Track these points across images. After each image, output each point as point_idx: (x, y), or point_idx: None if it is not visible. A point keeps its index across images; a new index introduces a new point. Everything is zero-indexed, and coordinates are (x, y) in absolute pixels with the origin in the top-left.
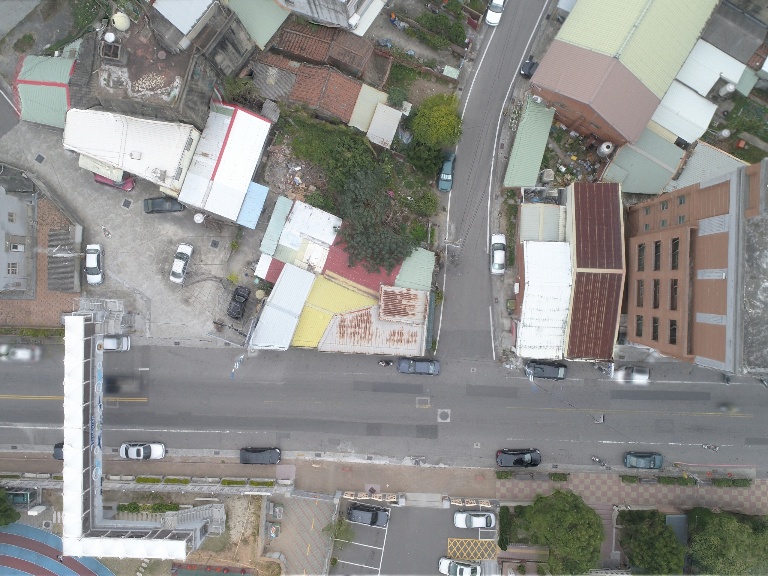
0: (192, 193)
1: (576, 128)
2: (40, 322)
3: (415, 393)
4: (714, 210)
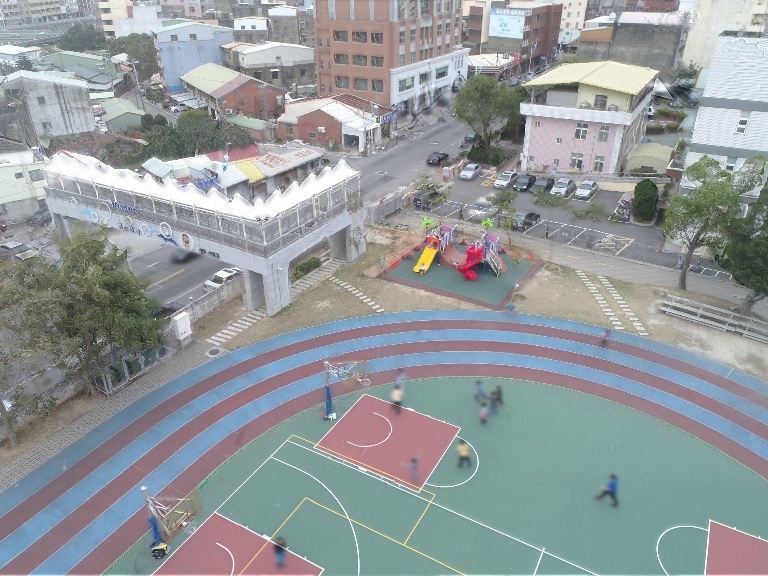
0: None
1: (260, 118)
2: None
3: None
4: (326, 7)
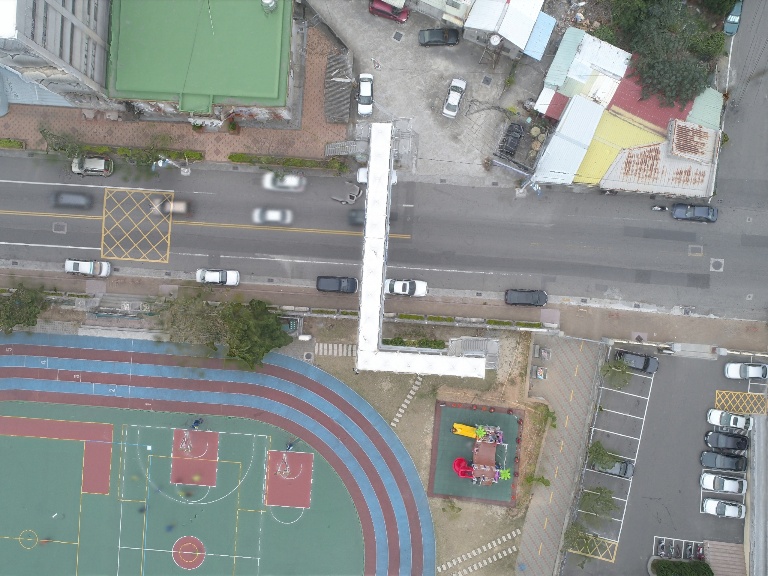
0: (483, 18)
1: None
2: (303, 153)
3: (688, 241)
4: None
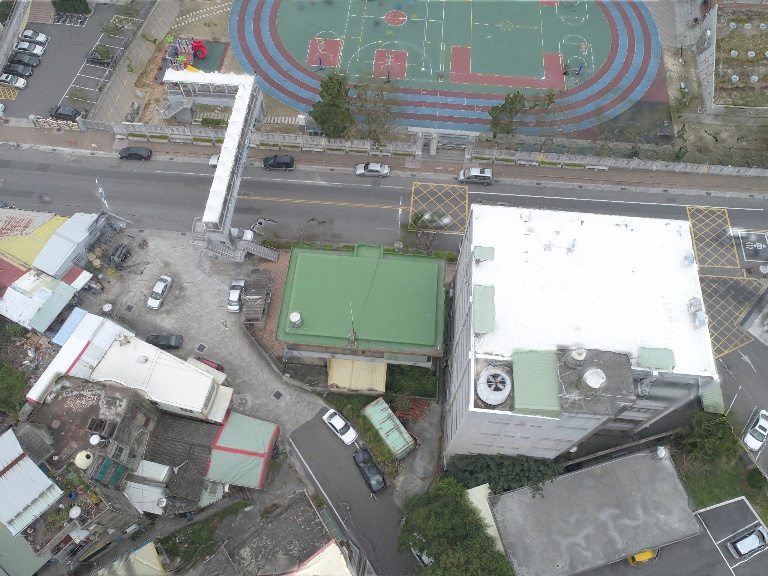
0: None
1: None
2: None
3: (0, 189)
4: None
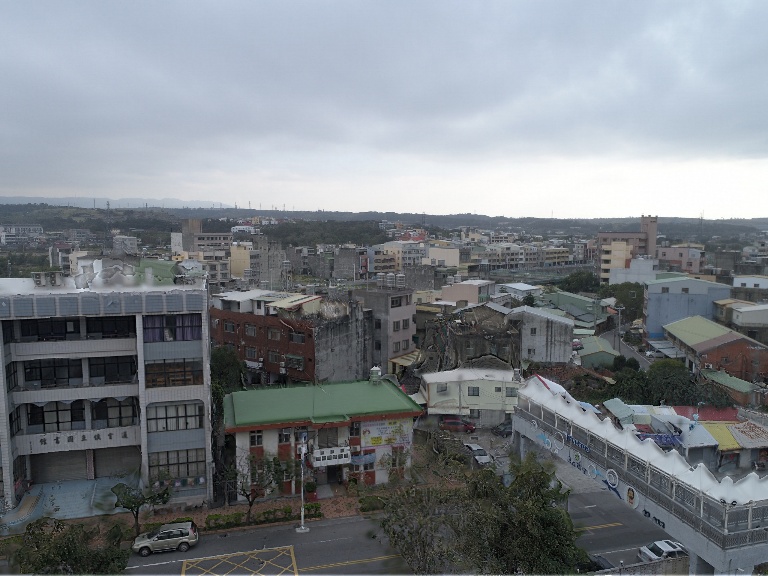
0: None
1: (745, 378)
2: None
3: None
4: None
